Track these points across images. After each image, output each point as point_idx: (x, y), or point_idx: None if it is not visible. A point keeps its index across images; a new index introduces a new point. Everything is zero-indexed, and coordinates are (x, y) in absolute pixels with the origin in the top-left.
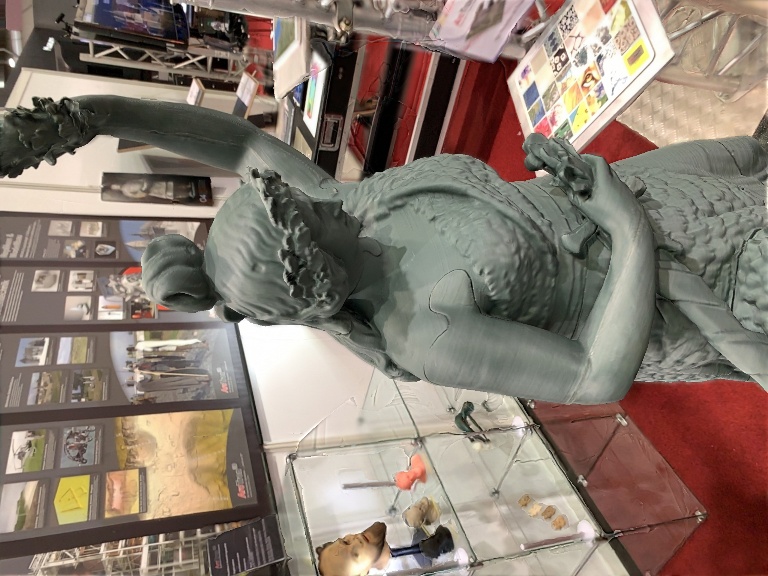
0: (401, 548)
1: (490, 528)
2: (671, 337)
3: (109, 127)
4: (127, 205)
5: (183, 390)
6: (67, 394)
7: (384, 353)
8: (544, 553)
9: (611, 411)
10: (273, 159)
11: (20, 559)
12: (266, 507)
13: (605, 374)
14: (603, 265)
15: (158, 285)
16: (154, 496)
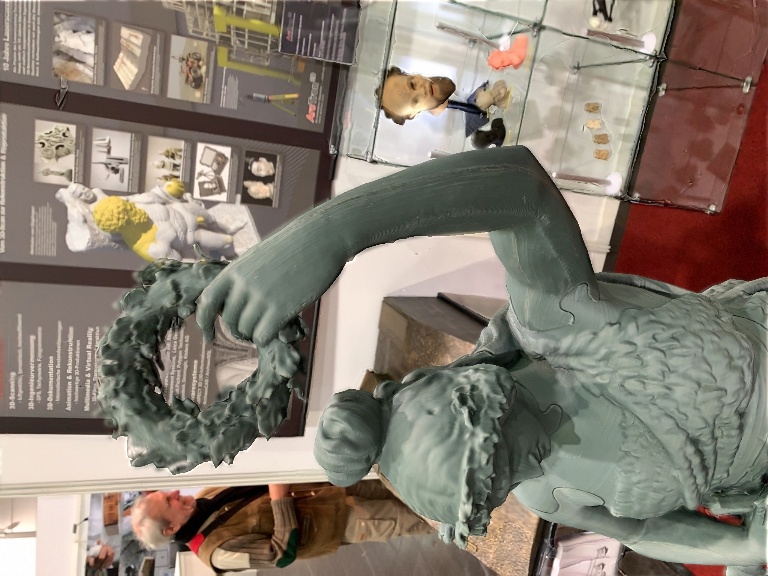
0: (458, 102)
1: (548, 91)
2: None
3: None
4: None
5: None
6: None
7: None
8: (575, 133)
9: (749, 65)
10: (531, 258)
11: None
12: None
13: None
14: None
15: None
16: None
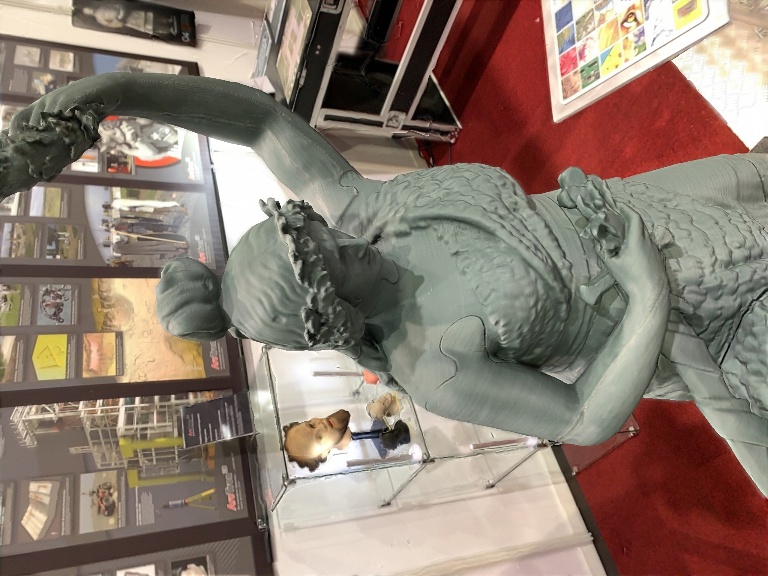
0: (361, 432)
1: None
2: (660, 380)
3: (118, 111)
4: (101, 35)
5: (160, 256)
6: (41, 249)
7: (388, 372)
8: None
9: None
10: (292, 146)
11: (1, 410)
12: (238, 379)
13: (594, 428)
14: (613, 313)
15: (175, 324)
16: (130, 360)
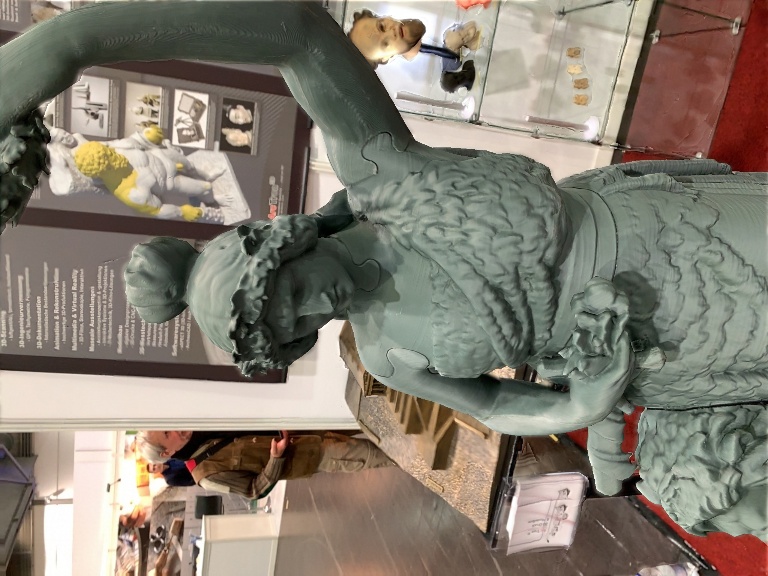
0: (433, 46)
1: (535, 39)
2: None
3: None
4: None
5: None
6: None
7: None
8: (564, 83)
9: (740, 5)
10: (316, 98)
11: None
12: None
13: None
14: None
15: None
16: None
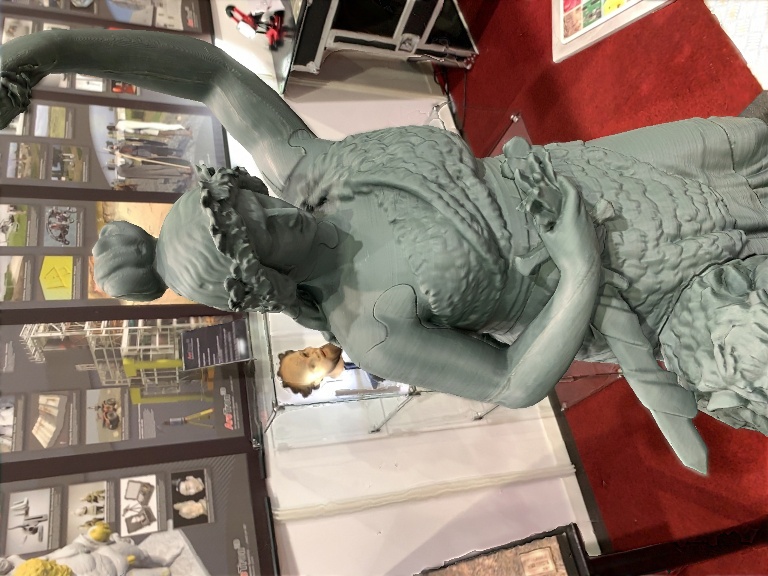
0: None
1: None
2: (597, 348)
3: (57, 69)
4: None
5: (164, 180)
6: (47, 170)
7: (329, 331)
8: None
9: None
10: (241, 104)
11: (11, 327)
12: None
13: (520, 393)
14: (550, 284)
15: (108, 286)
16: None
